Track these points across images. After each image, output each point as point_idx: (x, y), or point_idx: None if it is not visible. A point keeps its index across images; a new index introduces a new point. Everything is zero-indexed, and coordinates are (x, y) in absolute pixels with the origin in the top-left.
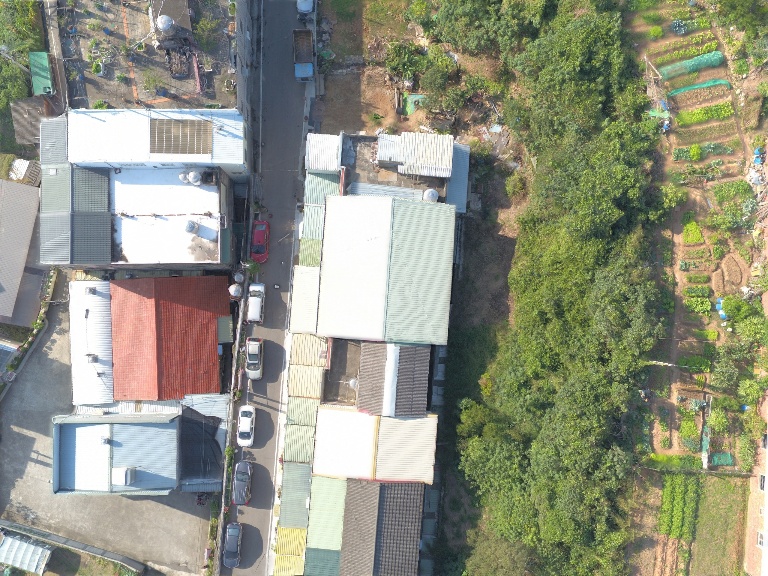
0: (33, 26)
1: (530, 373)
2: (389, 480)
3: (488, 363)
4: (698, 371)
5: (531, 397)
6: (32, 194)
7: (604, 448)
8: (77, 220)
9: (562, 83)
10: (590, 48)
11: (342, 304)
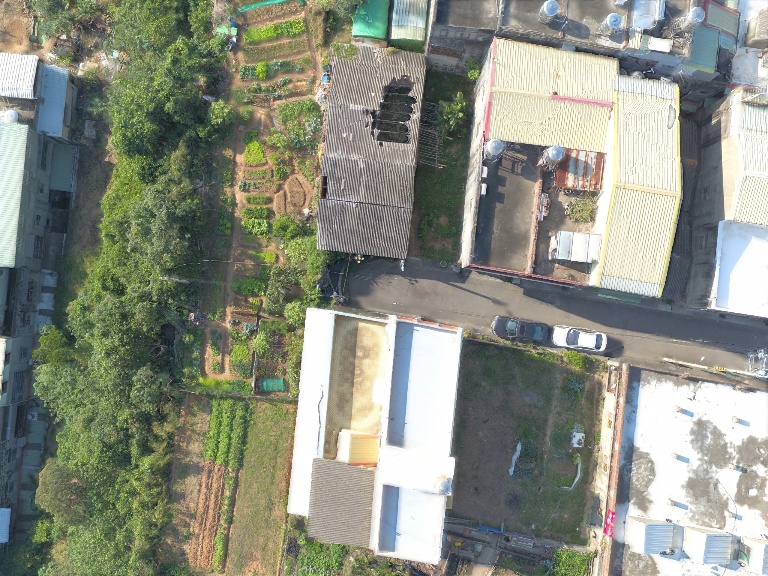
0: None
1: (93, 296)
2: None
3: (76, 290)
4: (254, 295)
5: (80, 319)
6: None
7: (135, 369)
8: None
9: (144, 1)
10: None
11: None
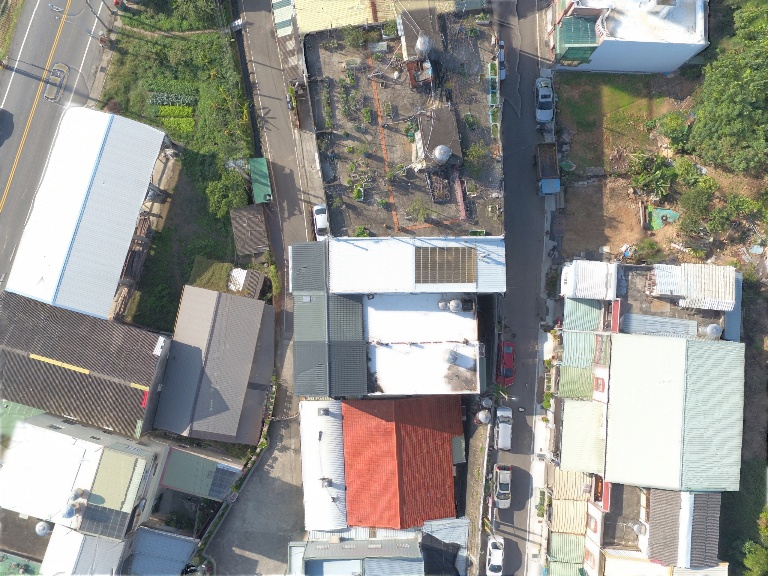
0: (246, 128)
1: None
2: None
3: (767, 502)
4: None
5: None
6: (255, 308)
7: None
8: (334, 350)
9: None
10: None
11: (632, 449)
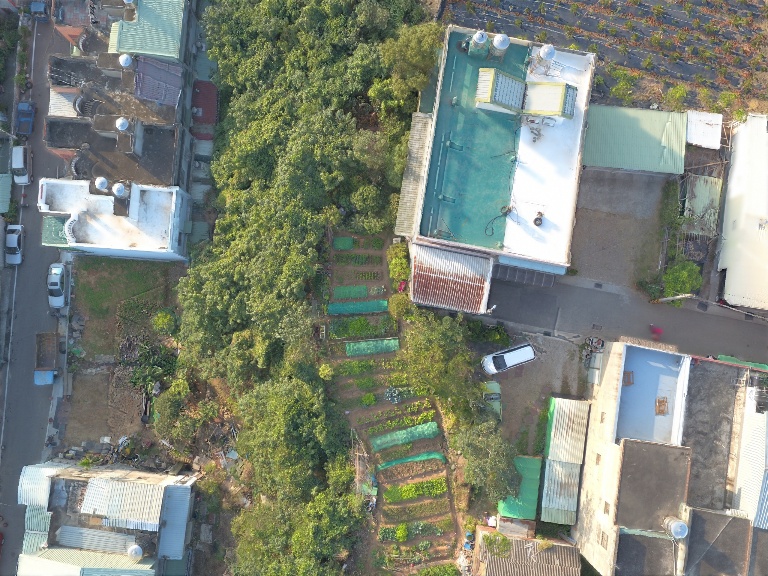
0: None
1: None
2: None
3: None
4: None
5: None
6: None
7: None
8: None
9: None
10: (293, 420)
11: None
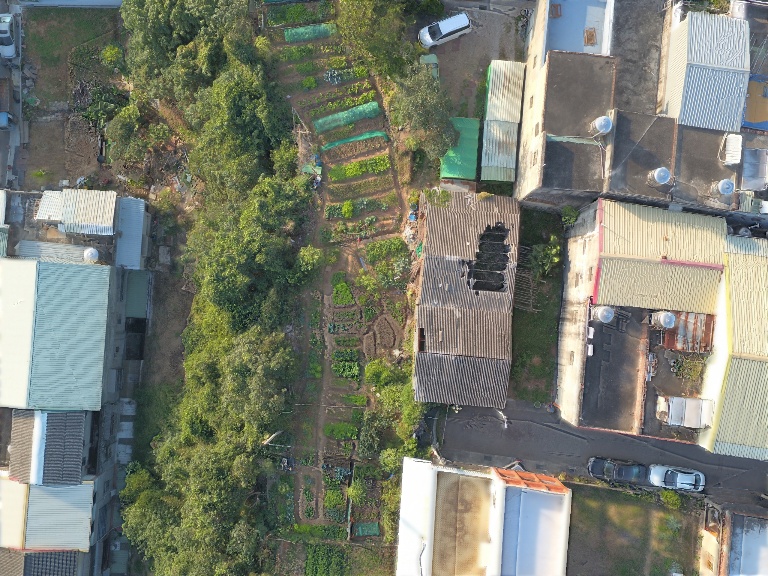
0: None
1: (182, 439)
2: (39, 549)
3: (160, 425)
4: (347, 438)
5: (172, 466)
6: None
7: (232, 522)
8: None
9: (223, 136)
10: (235, 102)
11: None
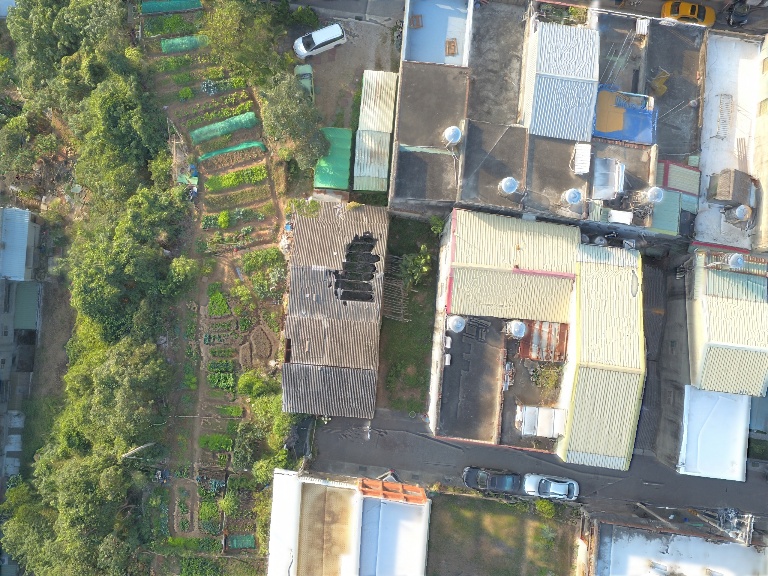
0: None
1: (59, 452)
2: None
3: (43, 437)
4: (222, 450)
5: (45, 480)
6: None
7: (101, 536)
8: None
9: (103, 147)
10: (109, 113)
11: None
